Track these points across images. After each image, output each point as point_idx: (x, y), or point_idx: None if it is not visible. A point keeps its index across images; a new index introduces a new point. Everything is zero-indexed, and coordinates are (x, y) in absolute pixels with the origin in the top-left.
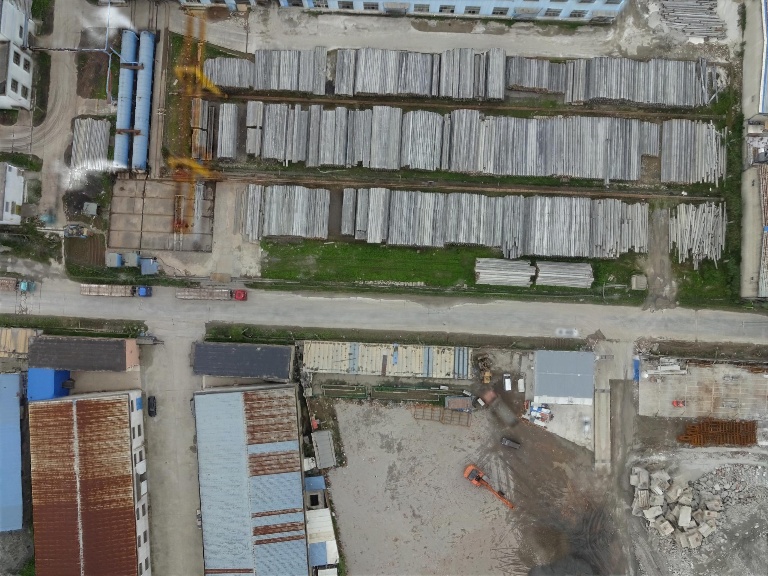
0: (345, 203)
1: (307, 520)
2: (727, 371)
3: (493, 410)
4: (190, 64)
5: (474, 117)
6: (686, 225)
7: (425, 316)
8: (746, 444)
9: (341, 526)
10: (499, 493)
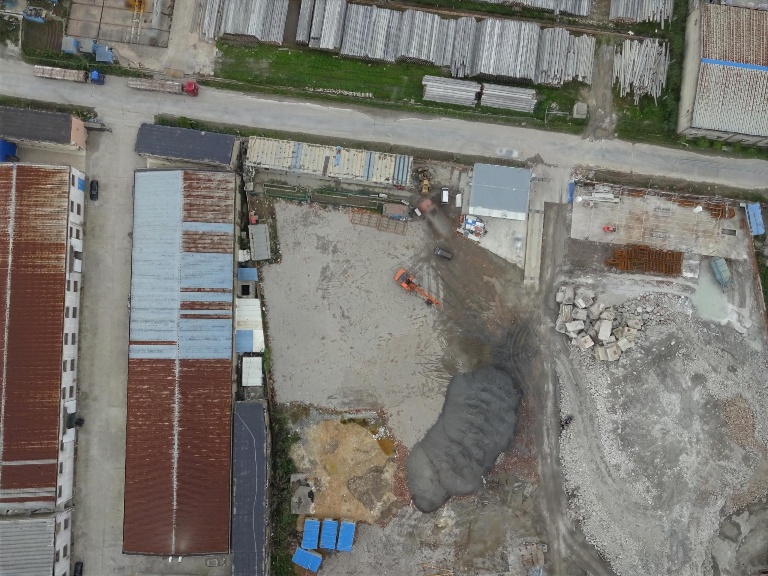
0: (302, 11)
1: (236, 305)
2: (659, 203)
3: (429, 222)
4: None
5: None
6: (629, 60)
7: (371, 127)
8: (671, 273)
9: (270, 320)
10: (428, 300)
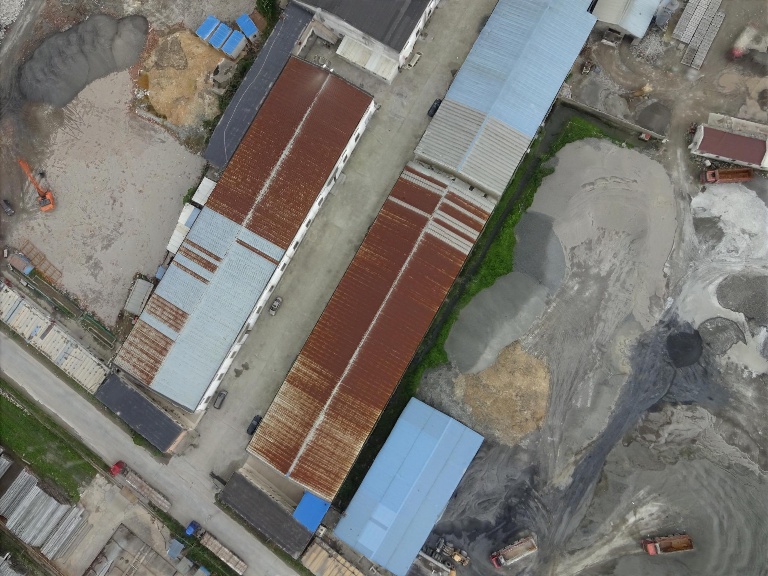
0: None
1: None
2: None
3: (3, 241)
4: None
5: None
6: None
7: None
8: None
9: (173, 229)
10: (41, 177)
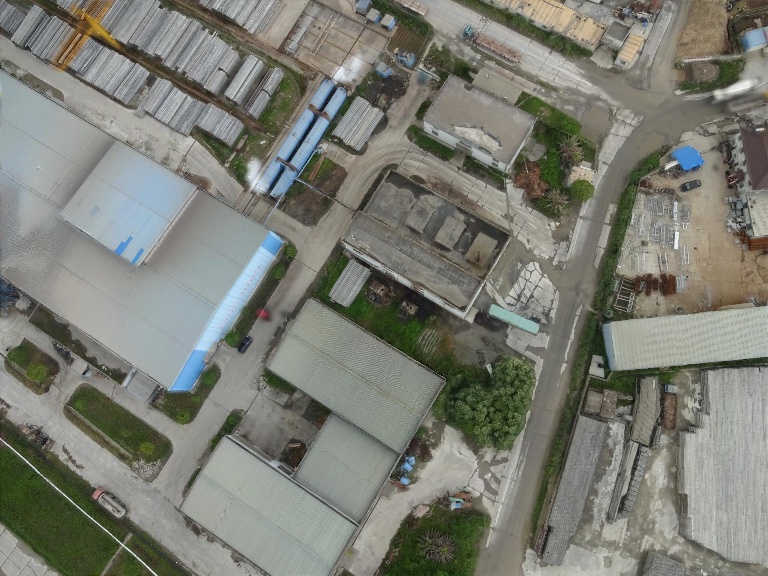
0: None
1: None
2: None
3: None
4: (243, 151)
5: (62, 0)
6: None
7: None
8: None
9: None
10: None
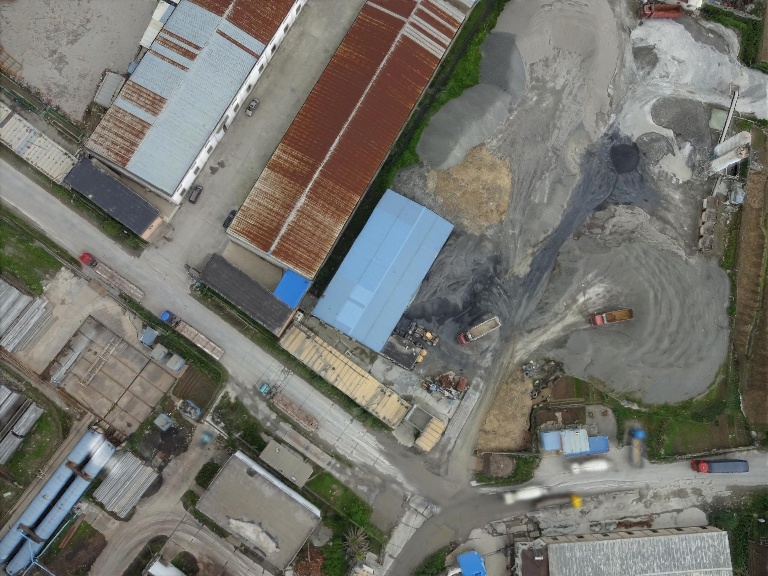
0: None
1: None
2: None
3: None
4: None
5: None
6: None
7: None
8: None
9: (145, 28)
10: None
